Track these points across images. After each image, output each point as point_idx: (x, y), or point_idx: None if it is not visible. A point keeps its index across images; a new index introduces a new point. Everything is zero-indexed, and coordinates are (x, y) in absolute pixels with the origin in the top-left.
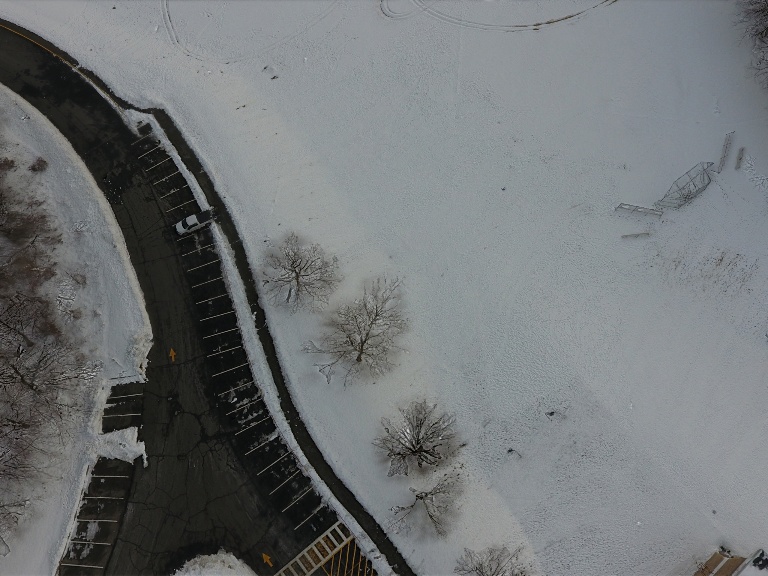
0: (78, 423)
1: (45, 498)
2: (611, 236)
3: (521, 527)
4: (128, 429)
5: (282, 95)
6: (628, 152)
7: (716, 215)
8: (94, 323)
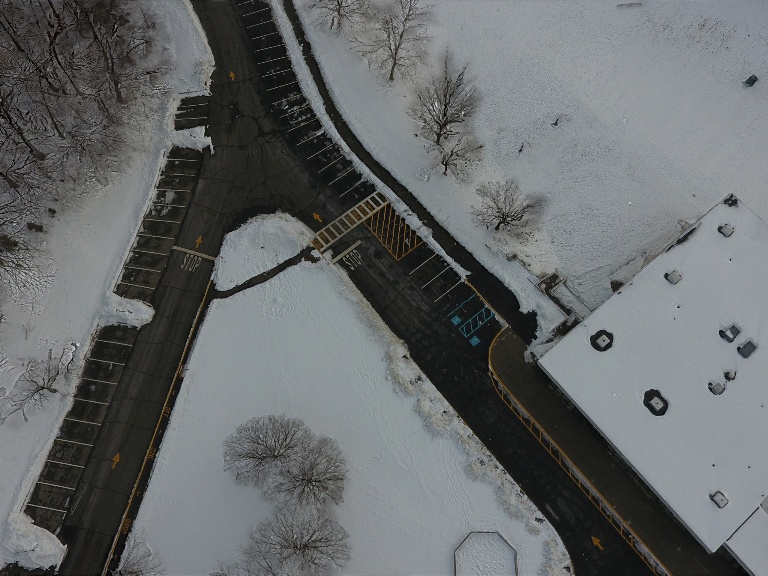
0: (154, 123)
1: (129, 172)
2: (608, 5)
3: None
4: (197, 127)
5: None
6: None
7: None
8: (164, 56)
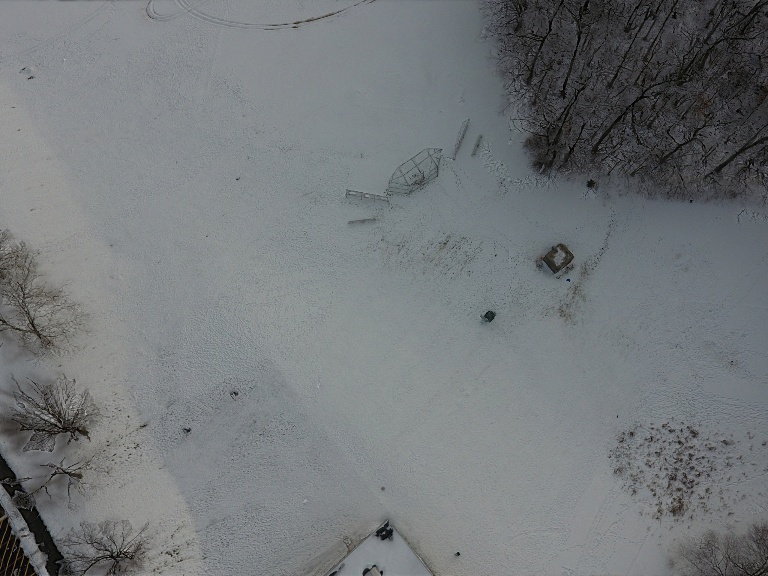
0: None
1: None
2: (338, 222)
3: (186, 506)
4: None
5: (35, 94)
6: (367, 141)
7: (446, 200)
8: None
